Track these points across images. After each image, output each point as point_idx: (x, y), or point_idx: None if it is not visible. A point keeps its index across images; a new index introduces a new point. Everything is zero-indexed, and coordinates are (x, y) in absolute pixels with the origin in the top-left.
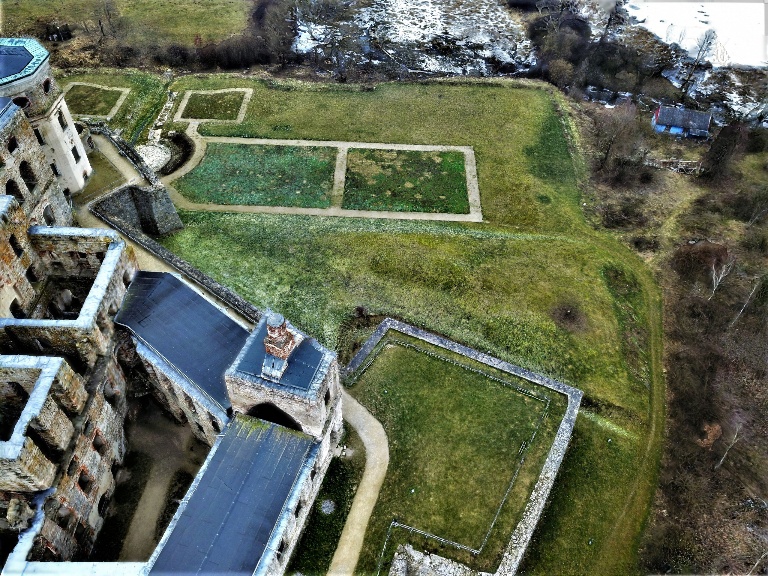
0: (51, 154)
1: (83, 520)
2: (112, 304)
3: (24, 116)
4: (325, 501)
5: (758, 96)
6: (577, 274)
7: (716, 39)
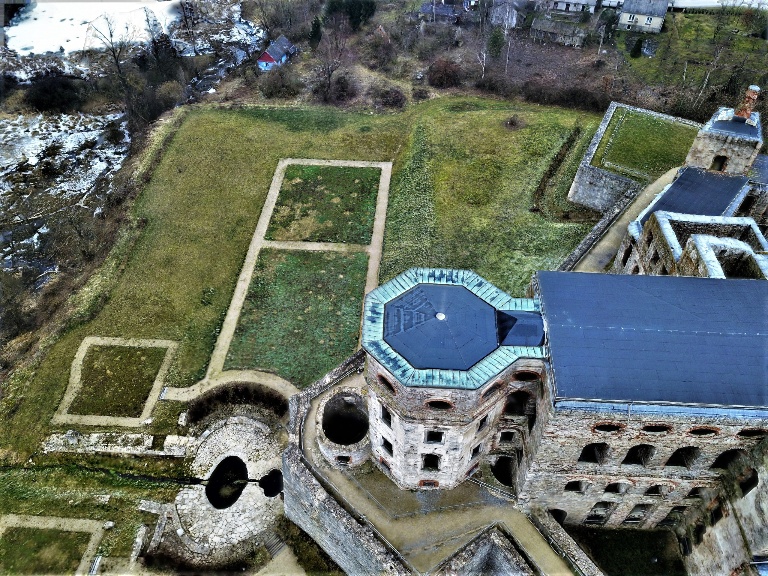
0: None
1: None
2: None
3: None
4: None
5: (223, 27)
6: None
7: (193, 3)
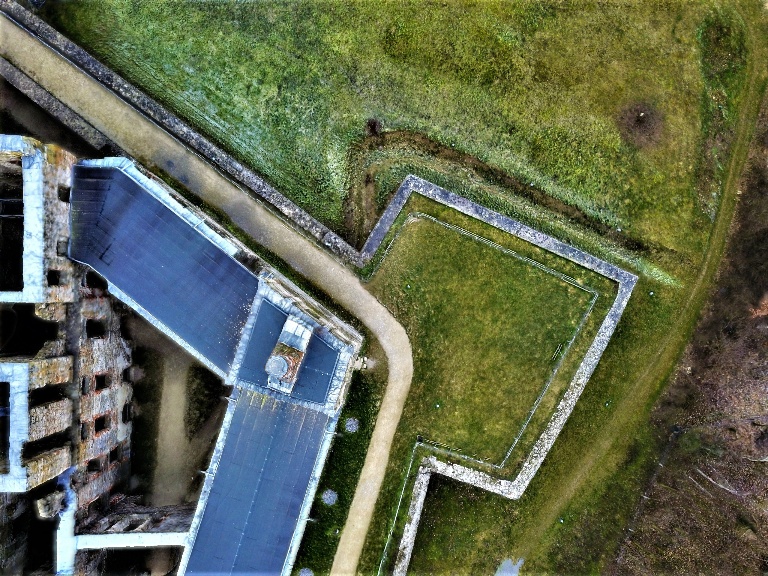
0: None
1: (113, 447)
2: (58, 239)
3: None
4: (349, 419)
5: None
6: (665, 40)
7: None
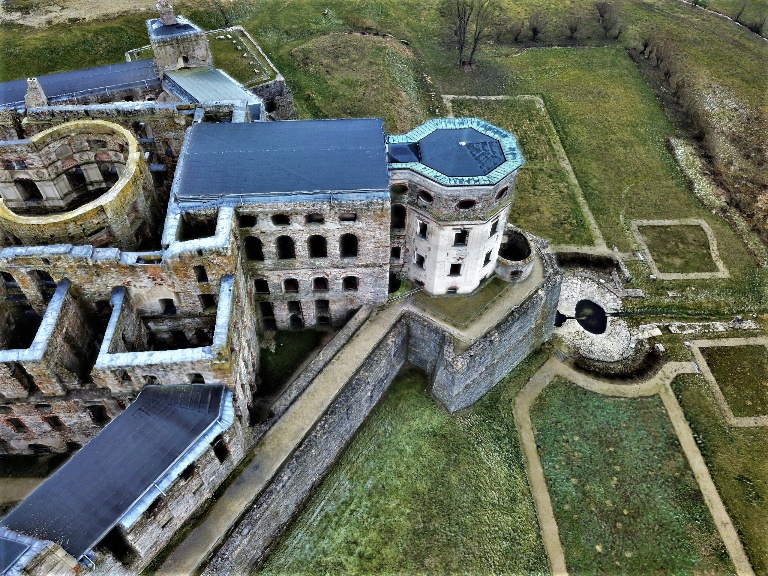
0: (427, 250)
1: (3, 437)
2: None
3: (387, 208)
4: None
5: None
6: None
7: None
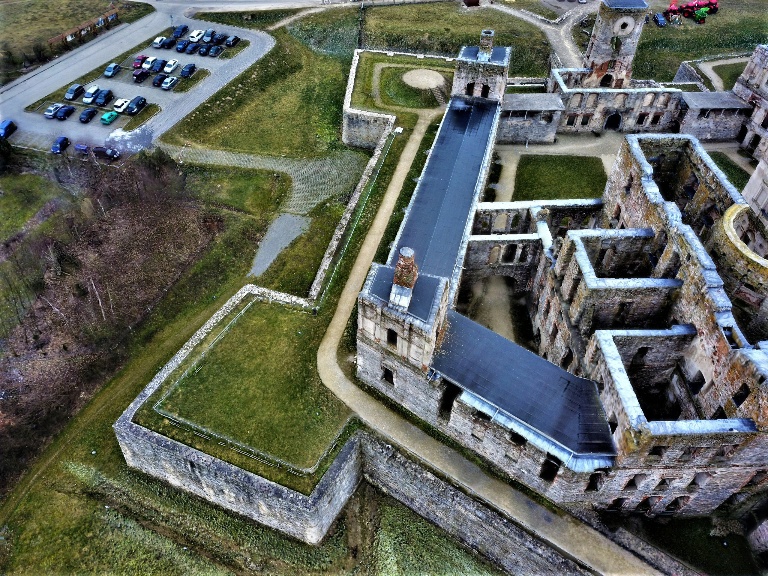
0: None
1: None
2: None
3: None
4: None
5: None
6: None
7: None
